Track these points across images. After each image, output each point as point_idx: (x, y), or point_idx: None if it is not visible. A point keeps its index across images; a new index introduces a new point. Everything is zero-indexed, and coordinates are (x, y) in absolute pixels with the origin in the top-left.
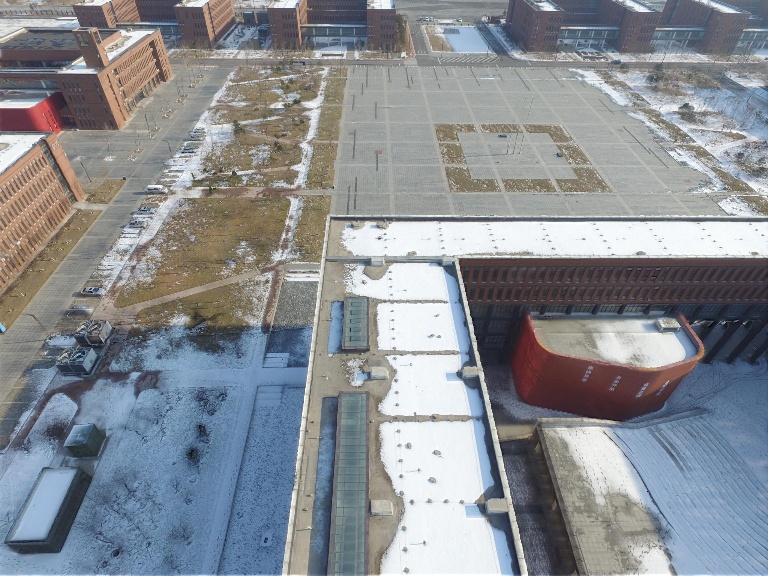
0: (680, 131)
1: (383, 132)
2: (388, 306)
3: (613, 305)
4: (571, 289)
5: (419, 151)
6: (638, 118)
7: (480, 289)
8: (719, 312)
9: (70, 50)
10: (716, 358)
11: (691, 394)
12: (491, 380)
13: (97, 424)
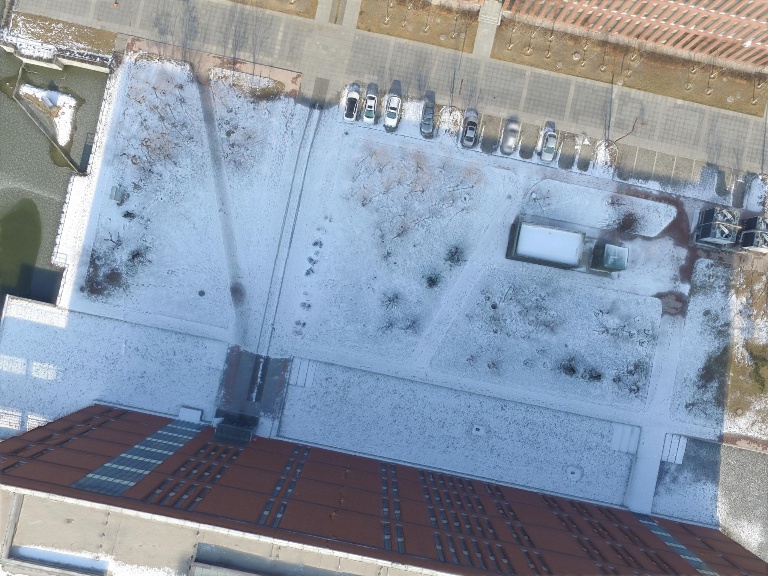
0: None
1: None
2: None
3: None
4: None
5: None
6: None
7: None
8: None
9: None
10: None
11: None
12: None
13: (628, 262)
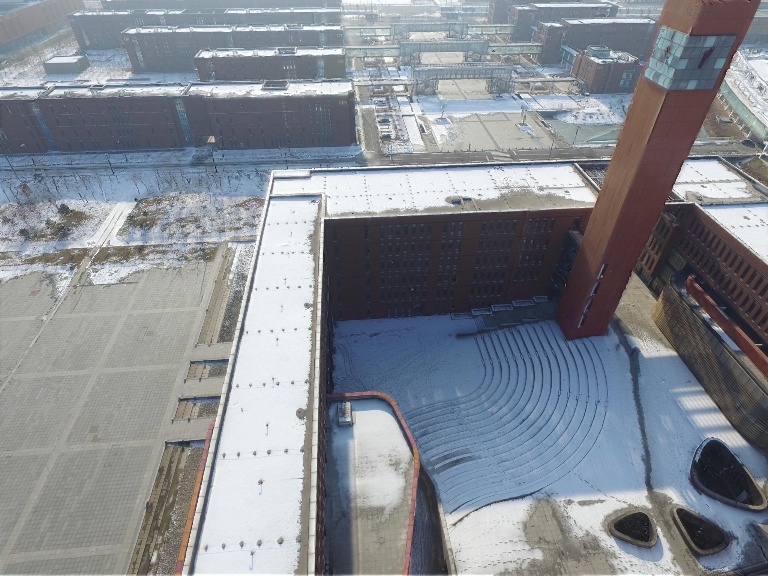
0: None
1: None
2: None
3: None
4: None
5: None
6: None
7: None
8: None
9: None
10: None
11: None
12: None
13: None
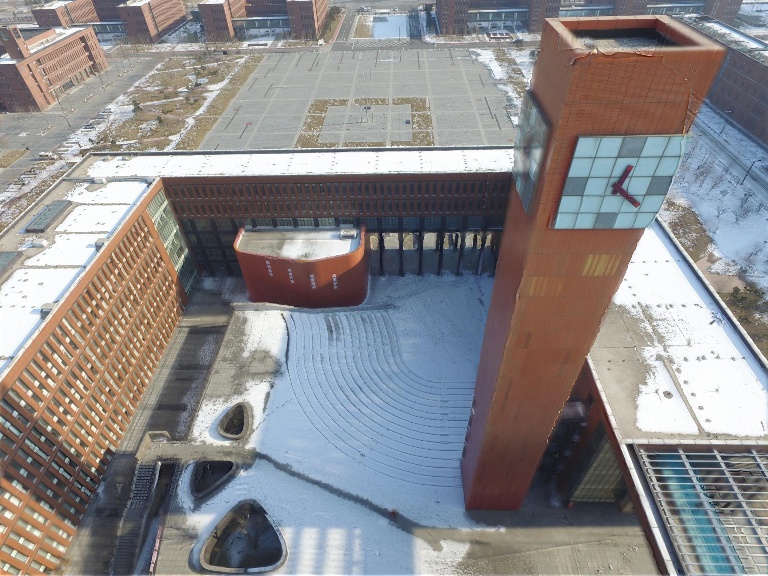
0: None
1: (263, 108)
2: (84, 207)
3: (308, 219)
4: (264, 204)
5: (285, 122)
6: (504, 89)
7: (193, 205)
8: (398, 225)
9: (2, 46)
10: (430, 271)
11: (390, 296)
12: (235, 286)
13: None
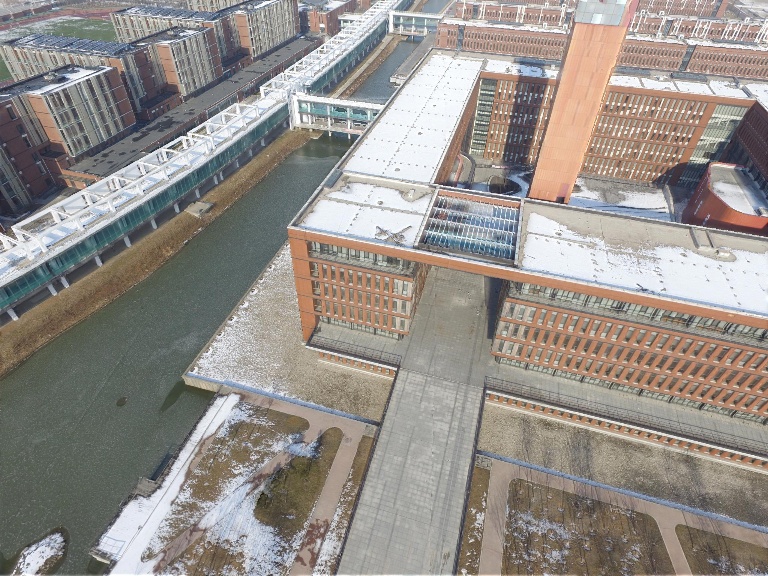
0: None
1: None
2: (705, 85)
3: None
4: (767, 157)
5: None
6: None
7: None
8: None
9: None
10: None
11: None
12: None
13: None
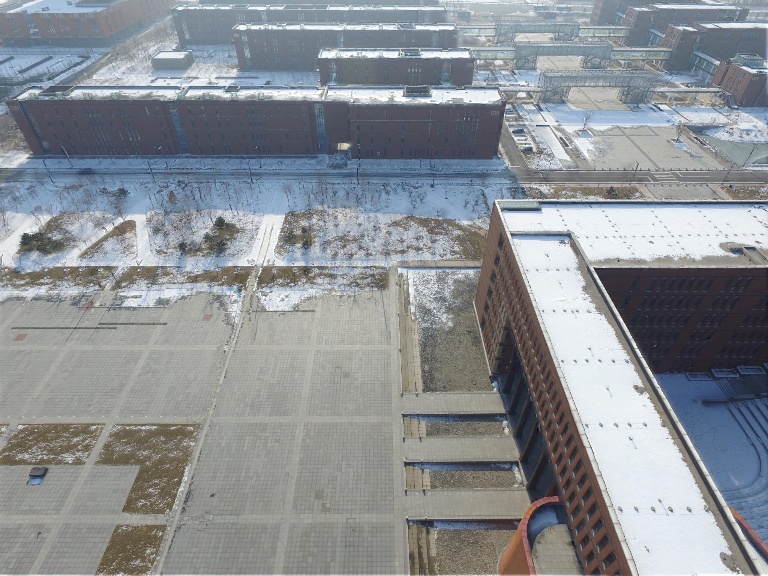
0: (78, 270)
1: None
2: None
3: None
4: None
5: None
6: (1, 299)
7: None
8: None
9: None
10: None
11: None
12: None
13: None
